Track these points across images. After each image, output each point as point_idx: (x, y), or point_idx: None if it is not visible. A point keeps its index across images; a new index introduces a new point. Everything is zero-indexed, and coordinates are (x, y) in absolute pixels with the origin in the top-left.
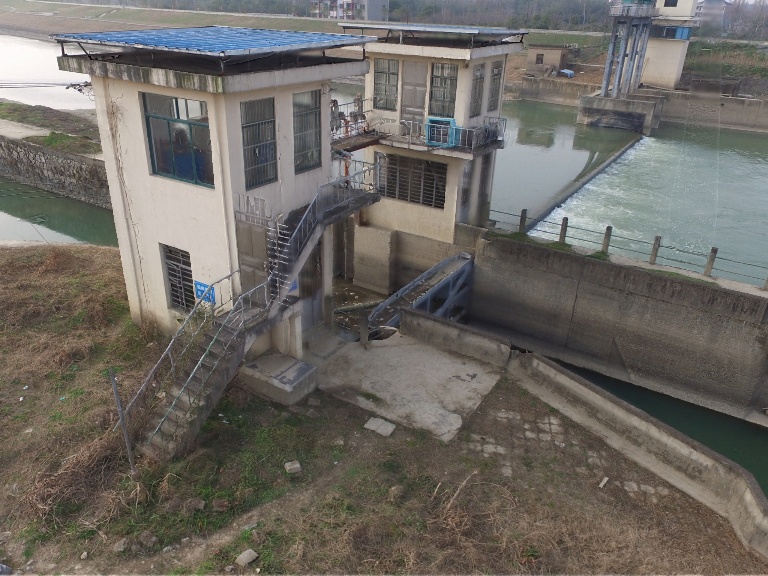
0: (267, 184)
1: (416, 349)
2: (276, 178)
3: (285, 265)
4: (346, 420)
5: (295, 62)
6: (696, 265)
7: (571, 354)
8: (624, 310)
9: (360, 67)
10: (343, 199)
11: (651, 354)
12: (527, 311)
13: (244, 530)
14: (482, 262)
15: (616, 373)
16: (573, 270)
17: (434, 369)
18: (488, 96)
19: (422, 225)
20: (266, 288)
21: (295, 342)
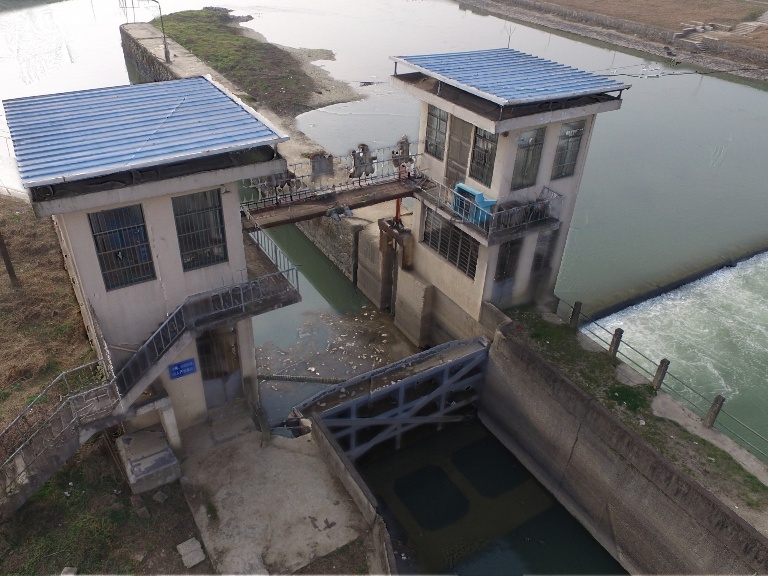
0: (140, 283)
1: (308, 464)
2: (154, 276)
3: (137, 369)
4: (169, 531)
5: (157, 174)
6: None
7: (564, 496)
8: (622, 480)
9: (269, 168)
10: (231, 305)
11: (643, 545)
12: (529, 428)
13: None
14: (495, 356)
15: (605, 542)
16: (577, 408)
17: (300, 499)
18: (553, 163)
19: (454, 290)
20: (108, 389)
21: (167, 430)
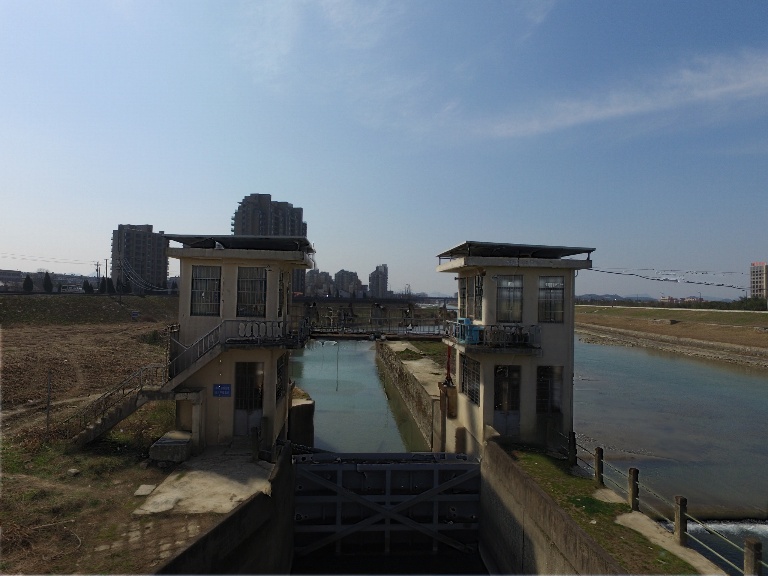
0: (210, 316)
1: (266, 474)
2: (219, 314)
3: (184, 362)
4: (146, 478)
5: (229, 246)
6: (733, 567)
7: None
8: (550, 572)
9: (293, 255)
10: (251, 335)
11: None
12: (501, 541)
13: (7, 477)
14: (482, 467)
15: None
16: (520, 493)
17: (239, 486)
18: (537, 307)
19: (472, 423)
20: None
21: (192, 425)
